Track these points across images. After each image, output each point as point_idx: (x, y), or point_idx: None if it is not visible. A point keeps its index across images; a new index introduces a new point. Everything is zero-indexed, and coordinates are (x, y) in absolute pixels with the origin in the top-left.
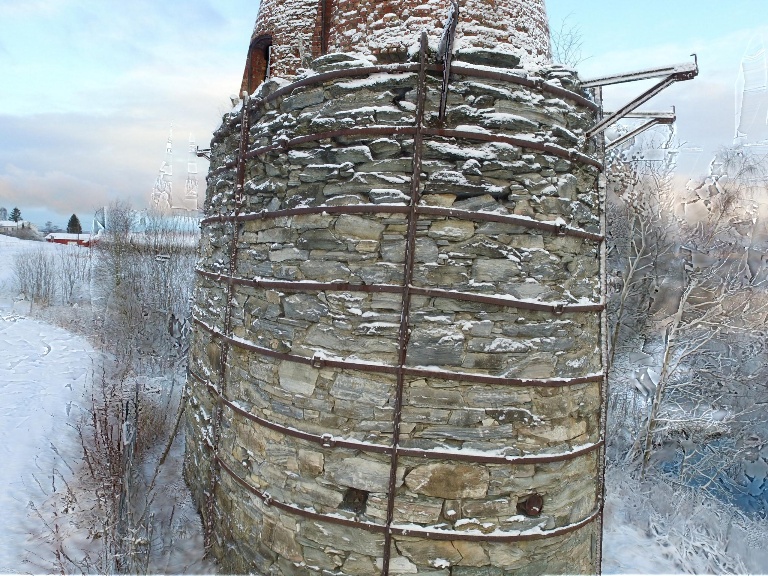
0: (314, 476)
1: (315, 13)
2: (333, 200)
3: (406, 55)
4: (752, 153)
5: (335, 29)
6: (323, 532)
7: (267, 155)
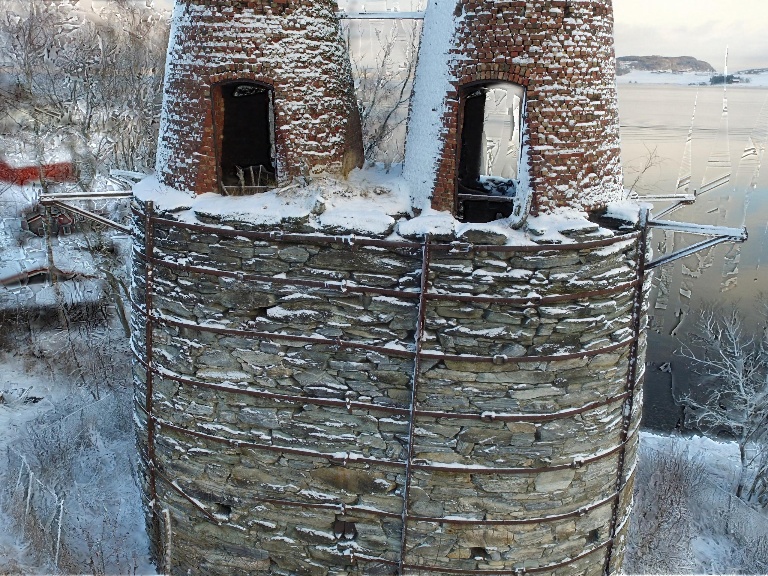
0: (567, 538)
1: (322, 61)
2: (592, 346)
3: (602, 209)
4: (392, 87)
5: (545, 181)
6: (574, 568)
7: (496, 305)
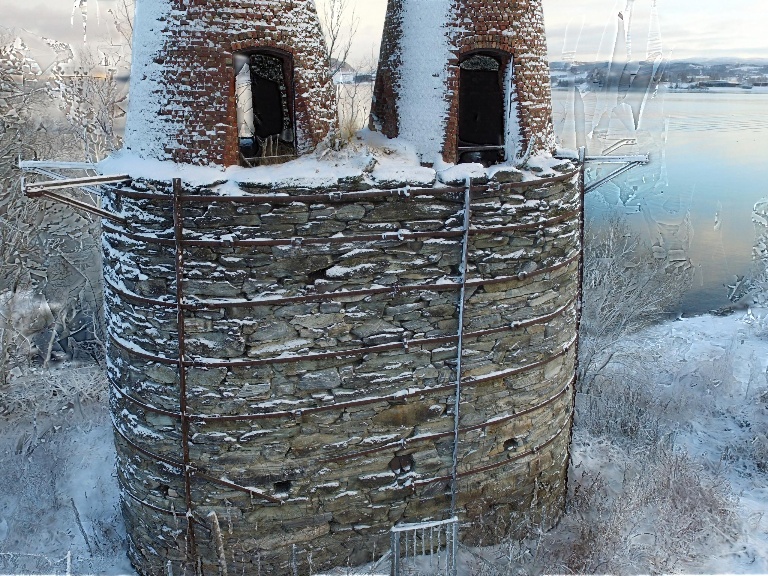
0: (558, 413)
1: None
2: None
3: None
4: None
5: None
6: None
7: None
